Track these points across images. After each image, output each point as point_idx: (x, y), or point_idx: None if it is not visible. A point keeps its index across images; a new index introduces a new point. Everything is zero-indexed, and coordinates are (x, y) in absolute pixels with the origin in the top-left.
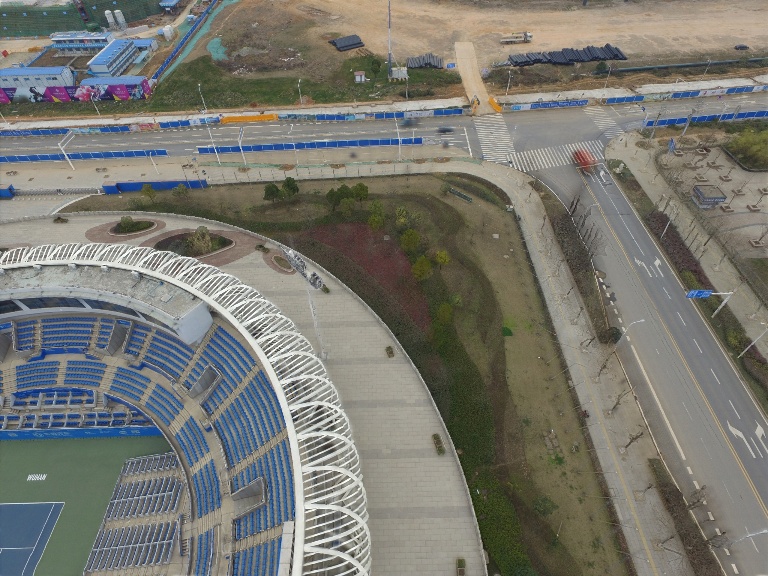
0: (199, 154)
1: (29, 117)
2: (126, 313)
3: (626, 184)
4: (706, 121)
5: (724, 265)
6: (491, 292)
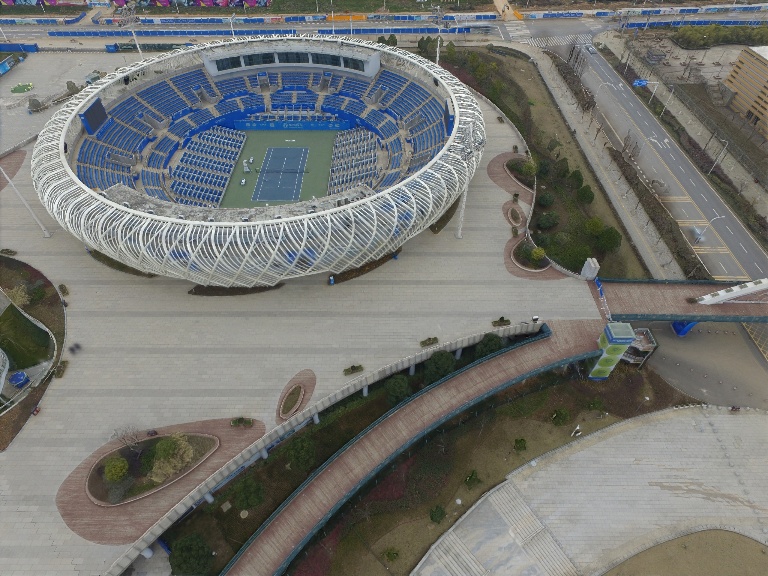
0: None
1: (186, 15)
2: (332, 65)
3: (605, 53)
4: (662, 26)
5: (660, 86)
6: (521, 90)
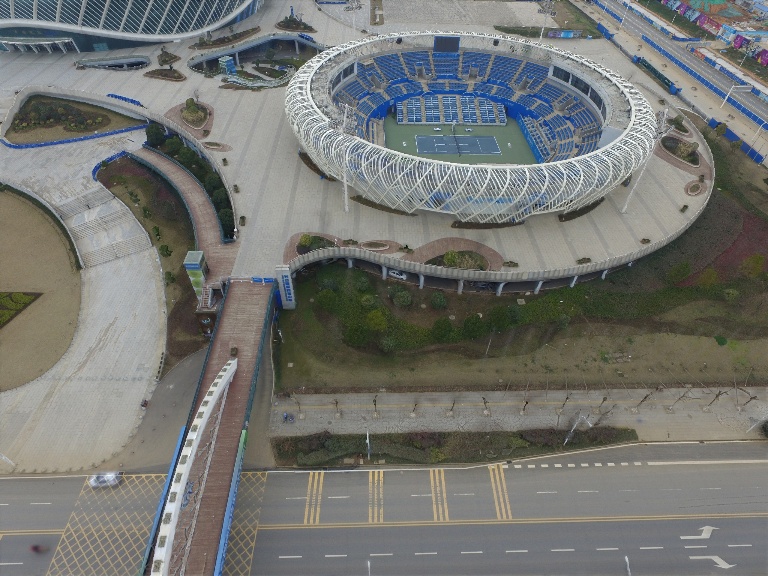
0: None
1: (758, 78)
2: None
3: None
4: None
5: None
6: (767, 334)
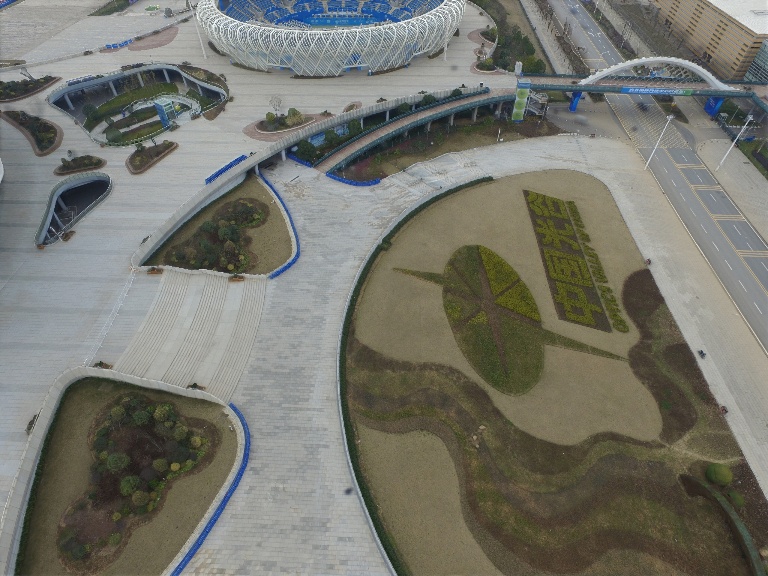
0: None
1: None
2: None
3: None
4: None
5: None
6: (502, 6)
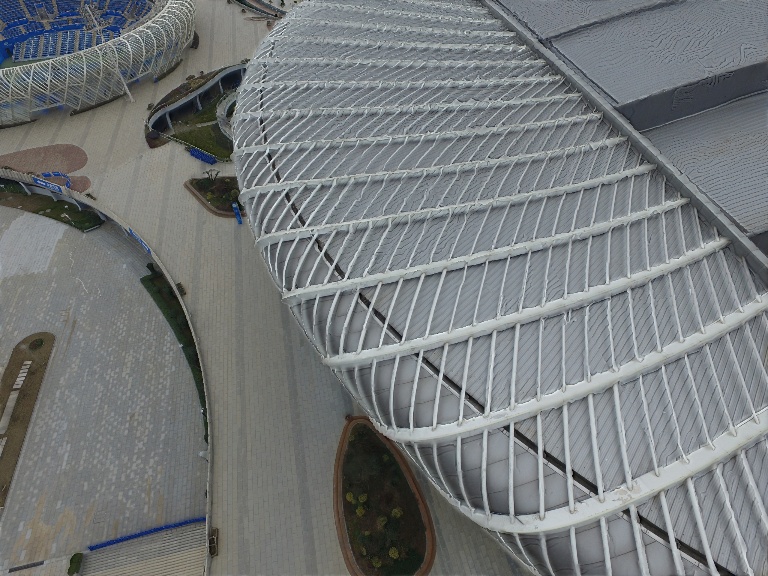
0: None
1: None
2: None
3: None
4: None
5: None
6: None
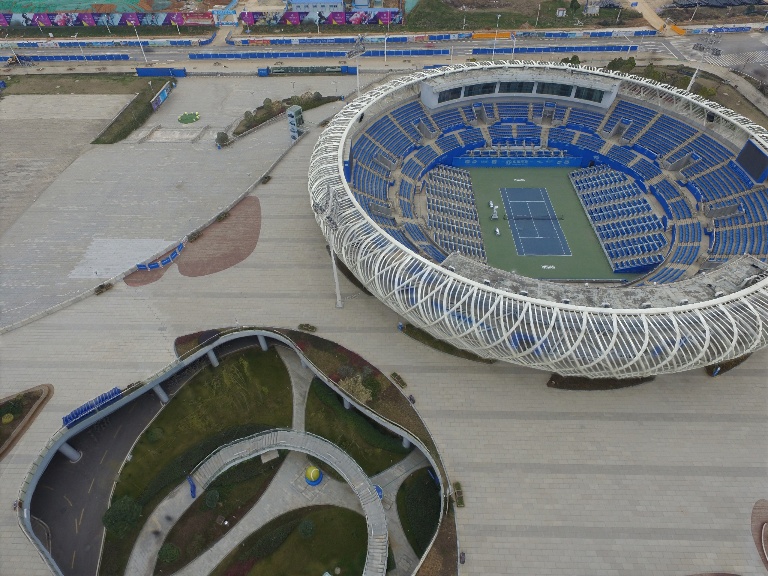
0: (472, 54)
1: (319, 33)
2: (559, 95)
3: None
4: None
5: None
6: None
